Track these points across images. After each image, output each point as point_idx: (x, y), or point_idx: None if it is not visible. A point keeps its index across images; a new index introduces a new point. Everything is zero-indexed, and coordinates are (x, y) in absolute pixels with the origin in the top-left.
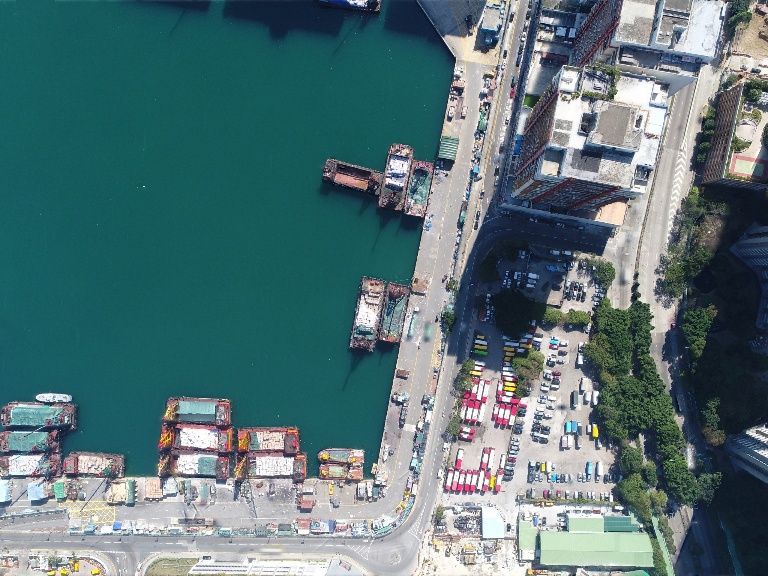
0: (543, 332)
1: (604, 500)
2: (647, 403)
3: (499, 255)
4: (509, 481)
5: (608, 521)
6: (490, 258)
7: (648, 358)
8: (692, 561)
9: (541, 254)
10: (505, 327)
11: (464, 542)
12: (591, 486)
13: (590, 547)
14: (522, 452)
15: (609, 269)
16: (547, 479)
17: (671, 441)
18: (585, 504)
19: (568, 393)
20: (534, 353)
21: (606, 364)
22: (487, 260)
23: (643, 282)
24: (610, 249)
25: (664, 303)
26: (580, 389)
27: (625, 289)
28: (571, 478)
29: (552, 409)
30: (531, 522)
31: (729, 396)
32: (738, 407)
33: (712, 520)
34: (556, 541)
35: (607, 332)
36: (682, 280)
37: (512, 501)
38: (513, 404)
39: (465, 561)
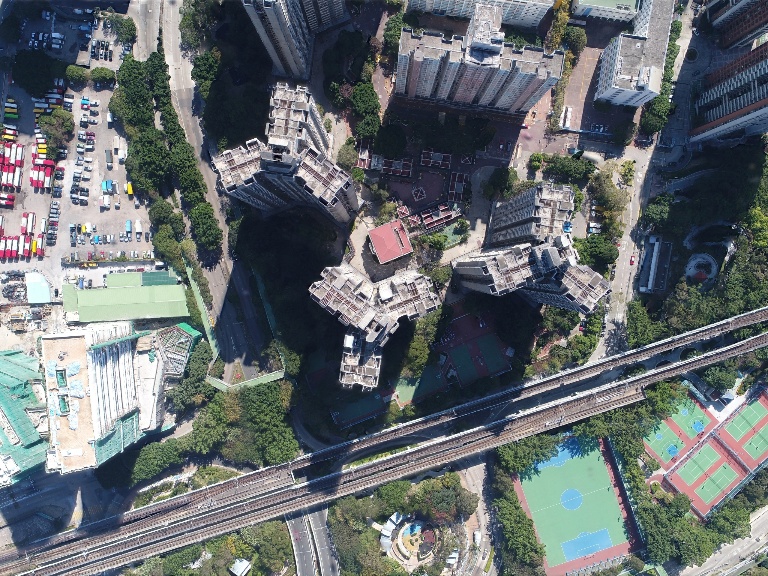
0: (74, 93)
1: (147, 258)
2: (161, 148)
3: (18, 14)
4: (53, 246)
5: (147, 276)
6: (9, 17)
7: (169, 109)
8: (235, 312)
9: (67, 15)
10: (20, 81)
11: (13, 310)
12: (134, 245)
13: (125, 300)
14: (63, 216)
15: (126, 22)
16: (90, 241)
17: (192, 187)
18: (129, 264)
19: (104, 153)
20: (58, 110)
21: (125, 115)
22: (5, 19)
23: (168, 38)
24: (134, 7)
25: (190, 58)
26: (114, 148)
27: (151, 46)
28: (111, 237)
29: (89, 170)
30: (77, 285)
31: (236, 135)
32: (245, 145)
33: (244, 267)
34: (92, 297)
35: (123, 83)
36: (192, 28)
37: (58, 266)
38: (48, 166)
39: (13, 328)
